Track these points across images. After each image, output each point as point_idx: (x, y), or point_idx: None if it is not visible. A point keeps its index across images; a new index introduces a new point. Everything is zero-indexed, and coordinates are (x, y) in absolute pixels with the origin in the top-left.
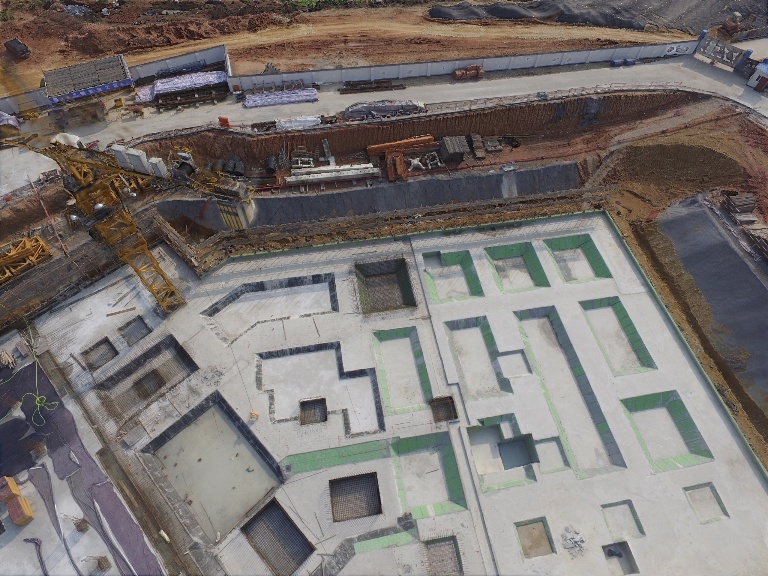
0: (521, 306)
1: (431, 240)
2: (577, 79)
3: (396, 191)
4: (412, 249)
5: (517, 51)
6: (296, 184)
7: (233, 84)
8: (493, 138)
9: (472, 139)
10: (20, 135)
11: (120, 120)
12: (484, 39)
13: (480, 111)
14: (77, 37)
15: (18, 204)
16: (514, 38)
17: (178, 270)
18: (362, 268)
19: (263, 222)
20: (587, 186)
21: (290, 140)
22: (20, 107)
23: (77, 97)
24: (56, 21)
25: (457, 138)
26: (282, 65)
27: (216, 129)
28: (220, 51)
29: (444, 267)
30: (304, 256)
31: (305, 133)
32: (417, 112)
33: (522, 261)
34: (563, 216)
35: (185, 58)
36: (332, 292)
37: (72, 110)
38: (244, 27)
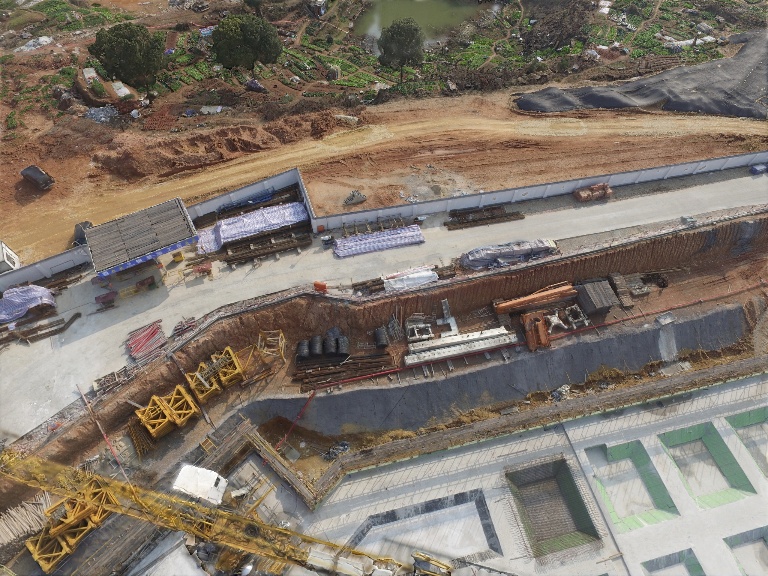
0: (730, 529)
1: (590, 427)
2: (720, 195)
3: (538, 362)
4: (570, 442)
5: (635, 155)
6: (418, 364)
7: (318, 225)
8: (635, 276)
9: (615, 282)
10: (58, 315)
11: (183, 284)
12: (590, 138)
13: (622, 247)
14: (109, 156)
15: (68, 433)
16: (623, 135)
17: (281, 498)
18: (514, 477)
19: (380, 417)
20: (756, 334)
21: (403, 304)
22: (53, 270)
23: (132, 266)
24: (79, 131)
25: (600, 285)
26: (366, 188)
27: (309, 294)
28: (291, 175)
29: (611, 464)
30: (438, 463)
31: (421, 294)
32: (548, 253)
33: (703, 447)
34: (739, 380)
35: (251, 188)
36: (484, 519)
37: (121, 274)
38: (307, 132)
